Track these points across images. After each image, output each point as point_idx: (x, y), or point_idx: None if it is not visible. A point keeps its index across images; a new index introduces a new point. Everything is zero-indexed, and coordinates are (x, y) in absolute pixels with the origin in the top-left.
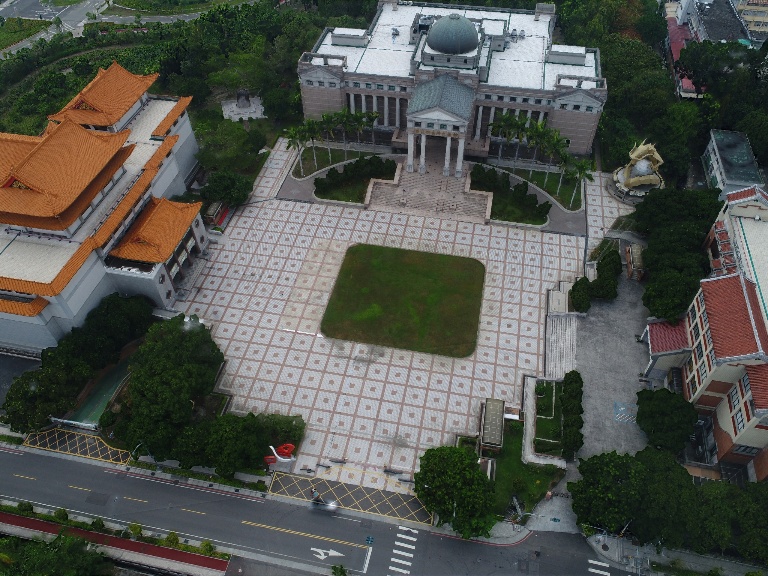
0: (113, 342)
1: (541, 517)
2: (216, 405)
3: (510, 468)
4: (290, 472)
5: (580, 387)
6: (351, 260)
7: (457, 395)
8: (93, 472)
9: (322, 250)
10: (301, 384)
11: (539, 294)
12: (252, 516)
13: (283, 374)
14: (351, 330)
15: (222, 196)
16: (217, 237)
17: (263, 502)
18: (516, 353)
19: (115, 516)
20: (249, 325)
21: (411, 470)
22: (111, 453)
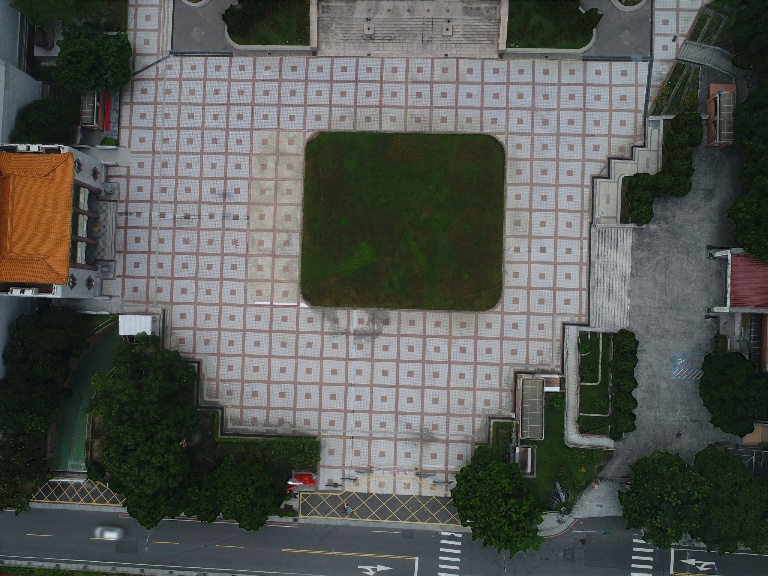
0: (54, 386)
1: (586, 505)
2: (209, 423)
3: (552, 451)
4: (316, 490)
5: (635, 354)
6: (315, 168)
7: (485, 366)
8: (108, 520)
9: (270, 154)
10: (299, 380)
11: (581, 187)
12: (290, 543)
13: (273, 370)
14: (341, 291)
15: (91, 85)
16: (113, 154)
17: (297, 527)
18: (553, 292)
19: (153, 562)
20: (210, 303)
21: (444, 468)
22: (117, 497)
